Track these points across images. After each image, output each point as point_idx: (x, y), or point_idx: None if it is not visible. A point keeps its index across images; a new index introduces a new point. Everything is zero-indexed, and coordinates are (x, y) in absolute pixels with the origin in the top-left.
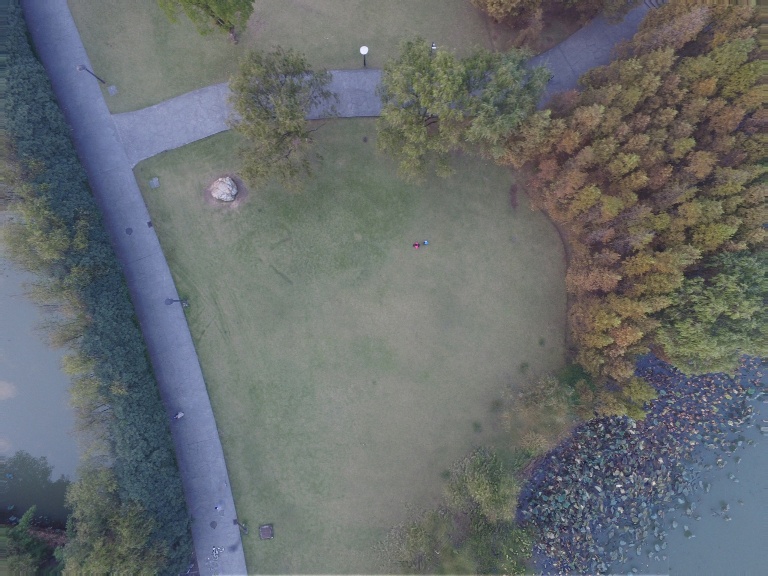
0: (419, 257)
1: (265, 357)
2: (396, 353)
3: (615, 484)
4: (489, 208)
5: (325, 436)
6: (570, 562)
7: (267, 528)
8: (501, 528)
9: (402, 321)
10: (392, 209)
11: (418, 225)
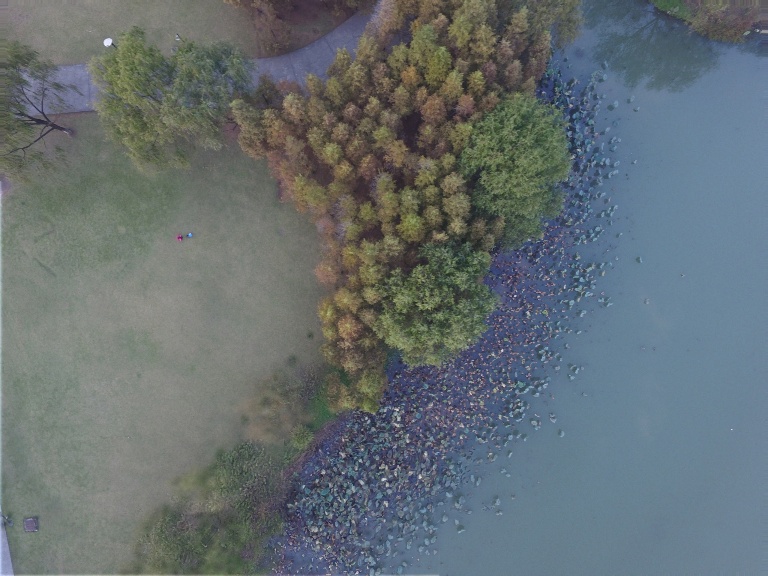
0: (184, 250)
1: (29, 350)
2: (161, 346)
3: (379, 477)
4: (255, 200)
5: (89, 429)
6: (338, 556)
7: (31, 521)
8: (269, 521)
9: (167, 314)
10: (156, 202)
11: (183, 218)
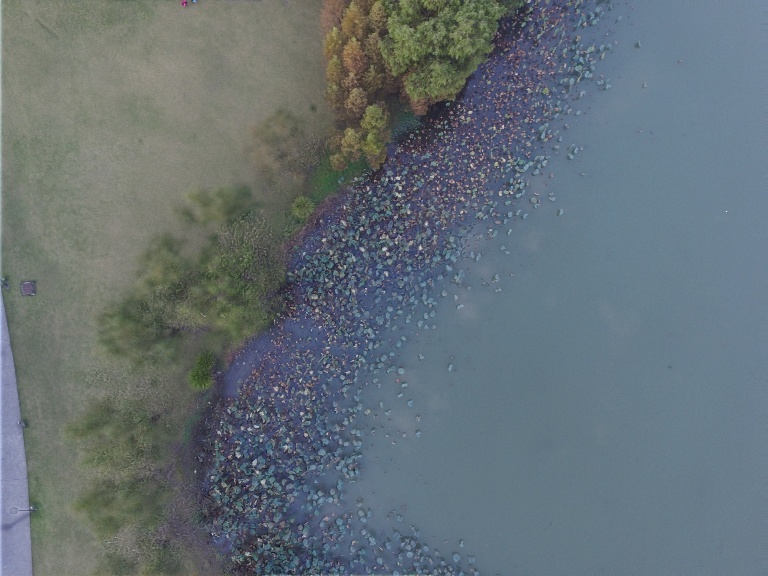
0: (188, 16)
1: (29, 112)
2: (163, 112)
3: (380, 246)
4: None
5: (89, 193)
6: (338, 328)
7: (28, 284)
8: (269, 292)
9: (170, 80)
10: None
11: None
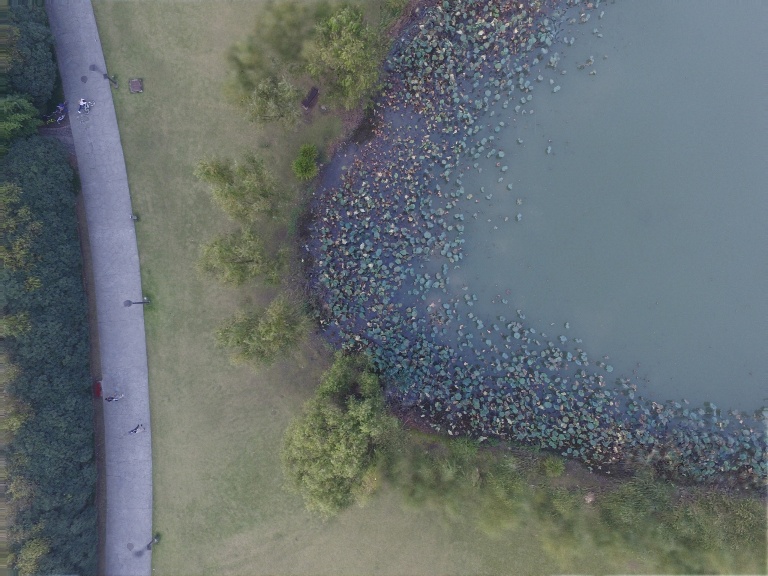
0: None
1: None
2: None
3: (477, 30)
4: None
5: None
6: (437, 115)
7: (136, 81)
8: (368, 83)
9: None
10: None
11: None
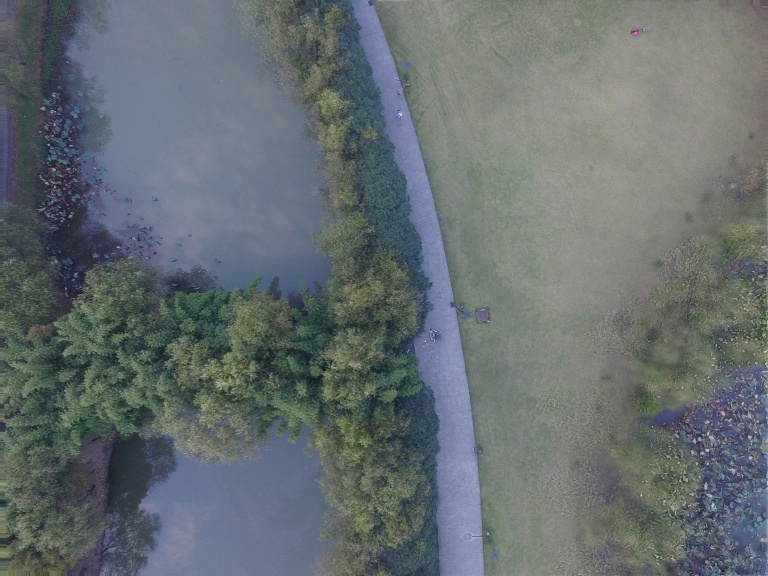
0: (636, 44)
1: (485, 139)
2: (612, 140)
3: None
4: None
5: (542, 220)
6: None
7: (484, 311)
8: (710, 318)
9: (619, 108)
10: None
11: (636, 13)
